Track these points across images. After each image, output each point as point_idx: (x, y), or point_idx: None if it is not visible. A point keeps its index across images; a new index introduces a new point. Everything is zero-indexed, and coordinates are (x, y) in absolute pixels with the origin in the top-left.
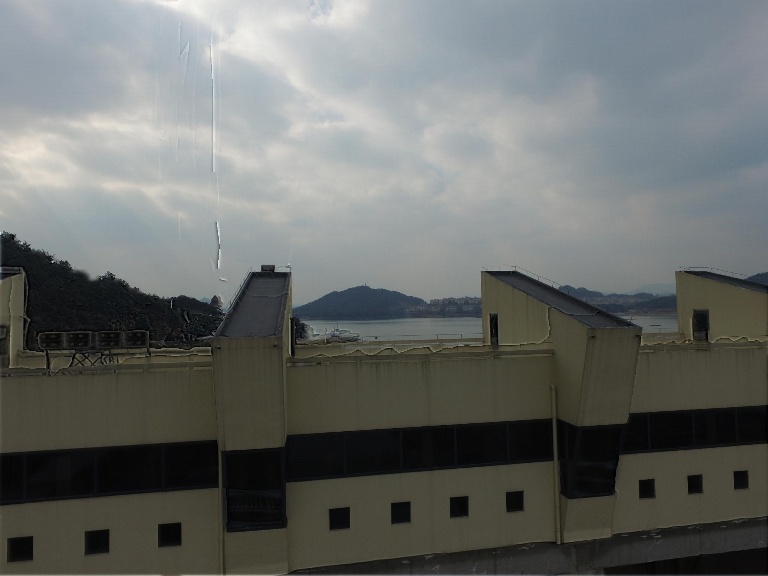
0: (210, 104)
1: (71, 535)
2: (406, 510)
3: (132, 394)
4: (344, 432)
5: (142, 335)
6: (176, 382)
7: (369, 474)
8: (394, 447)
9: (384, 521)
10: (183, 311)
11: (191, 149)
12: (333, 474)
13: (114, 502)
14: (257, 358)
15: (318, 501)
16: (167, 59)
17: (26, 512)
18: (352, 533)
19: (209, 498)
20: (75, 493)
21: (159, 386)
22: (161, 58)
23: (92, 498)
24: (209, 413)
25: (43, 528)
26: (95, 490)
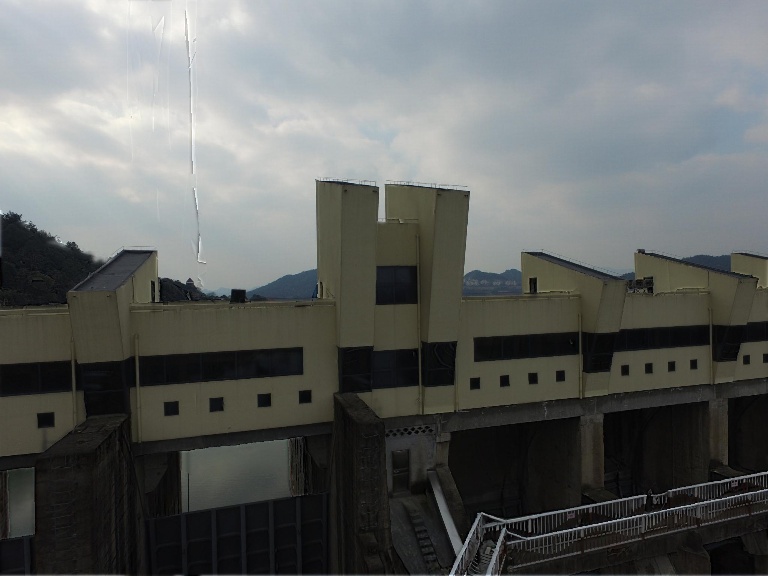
0: (187, 82)
1: (664, 363)
2: (767, 357)
3: (681, 304)
4: (748, 323)
5: (652, 281)
6: (695, 300)
7: (755, 341)
8: (763, 330)
9: (761, 361)
10: (186, 293)
11: (166, 128)
12: (744, 341)
13: (676, 350)
14: (749, 287)
15: (740, 352)
16: (137, 32)
17: (650, 353)
18: (751, 366)
19: (706, 349)
20: (663, 346)
21: (689, 301)
22: (130, 30)
23: (670, 348)
24: (705, 313)
25: (655, 360)
26: (670, 345)
